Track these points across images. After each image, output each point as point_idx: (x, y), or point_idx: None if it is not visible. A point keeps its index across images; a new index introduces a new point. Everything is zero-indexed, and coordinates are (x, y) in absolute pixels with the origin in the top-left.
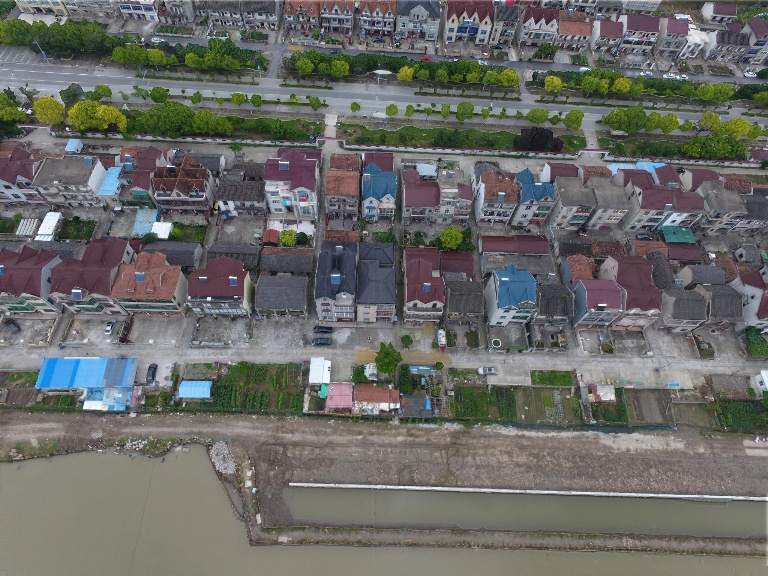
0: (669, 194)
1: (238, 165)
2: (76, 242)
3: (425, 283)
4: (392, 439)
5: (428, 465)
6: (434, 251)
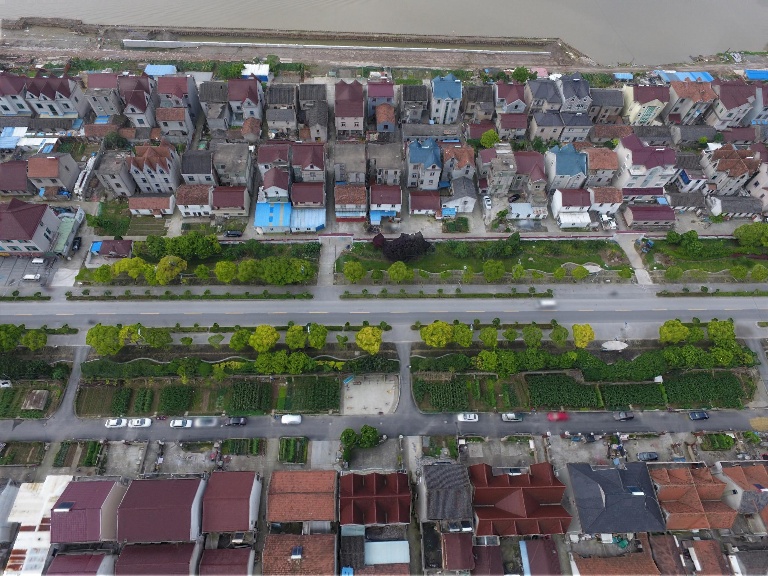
0: None
1: (700, 196)
2: (767, 139)
3: (512, 83)
4: (502, 66)
5: (480, 59)
6: (505, 122)
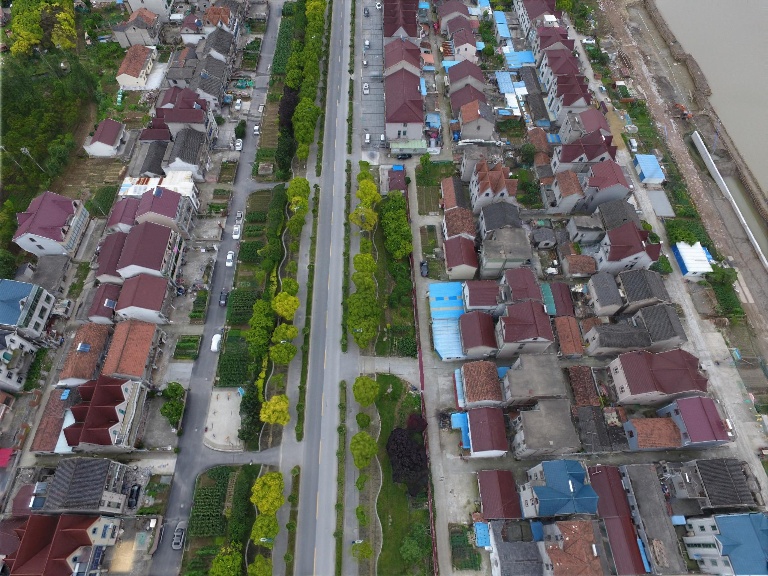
0: (534, 306)
1: None
2: None
3: None
4: None
5: None
6: None
